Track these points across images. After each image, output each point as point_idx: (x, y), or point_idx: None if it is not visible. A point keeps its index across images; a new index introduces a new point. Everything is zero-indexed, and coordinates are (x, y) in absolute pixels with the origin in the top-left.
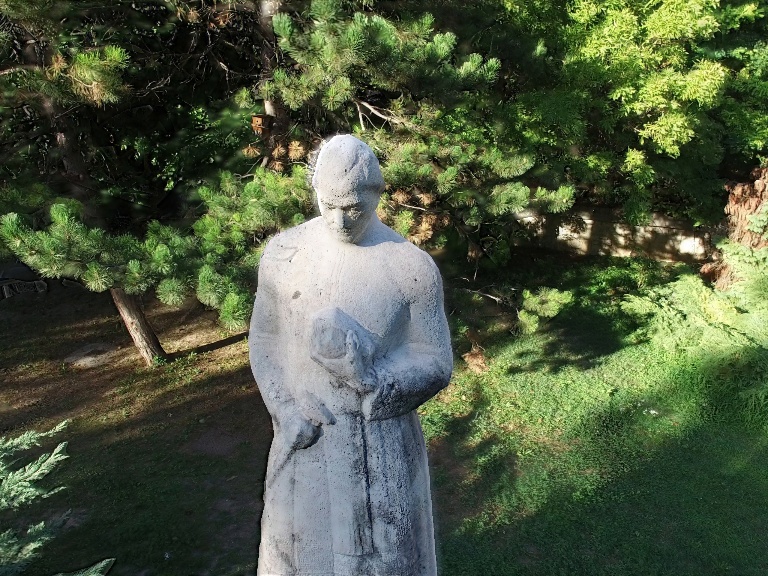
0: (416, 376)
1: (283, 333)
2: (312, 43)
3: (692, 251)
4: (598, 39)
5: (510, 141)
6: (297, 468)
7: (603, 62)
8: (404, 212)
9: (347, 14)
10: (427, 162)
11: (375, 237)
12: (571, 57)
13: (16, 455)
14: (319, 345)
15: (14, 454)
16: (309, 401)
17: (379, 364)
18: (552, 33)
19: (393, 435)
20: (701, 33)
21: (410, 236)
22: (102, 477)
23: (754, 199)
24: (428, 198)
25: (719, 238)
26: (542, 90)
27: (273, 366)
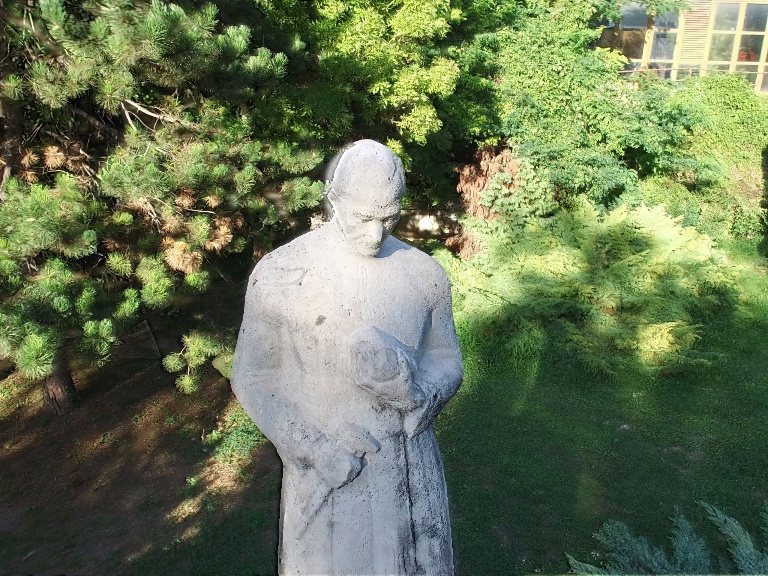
0: (449, 381)
1: (287, 365)
2: (92, 32)
3: (429, 228)
4: (352, 35)
5: (275, 136)
6: (335, 508)
7: (359, 58)
8: (197, 217)
9: (144, 0)
10: (218, 162)
11: (388, 246)
12: (327, 52)
13: None
14: (373, 369)
15: None
16: (354, 432)
17: (416, 376)
18: (299, 28)
19: (428, 446)
20: (439, 33)
21: (209, 242)
22: None
23: (481, 178)
24: (215, 200)
25: (459, 214)
26: (304, 84)
27: (284, 404)
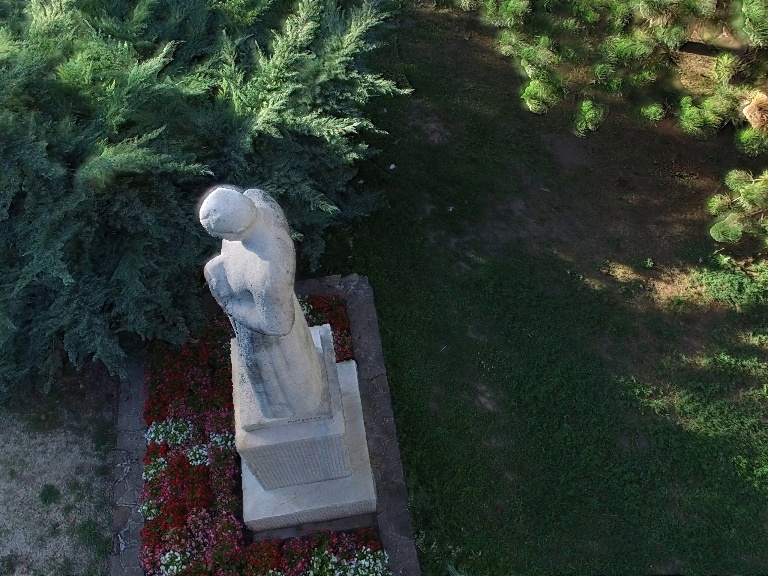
0: None
1: None
2: None
3: None
4: None
5: None
6: None
7: None
8: None
9: None
10: None
11: (252, 245)
12: None
13: (378, 92)
14: None
15: (377, 91)
16: None
17: (234, 300)
18: None
19: None
20: None
21: None
22: (482, 117)
23: None
24: None
25: None
26: None
27: None
